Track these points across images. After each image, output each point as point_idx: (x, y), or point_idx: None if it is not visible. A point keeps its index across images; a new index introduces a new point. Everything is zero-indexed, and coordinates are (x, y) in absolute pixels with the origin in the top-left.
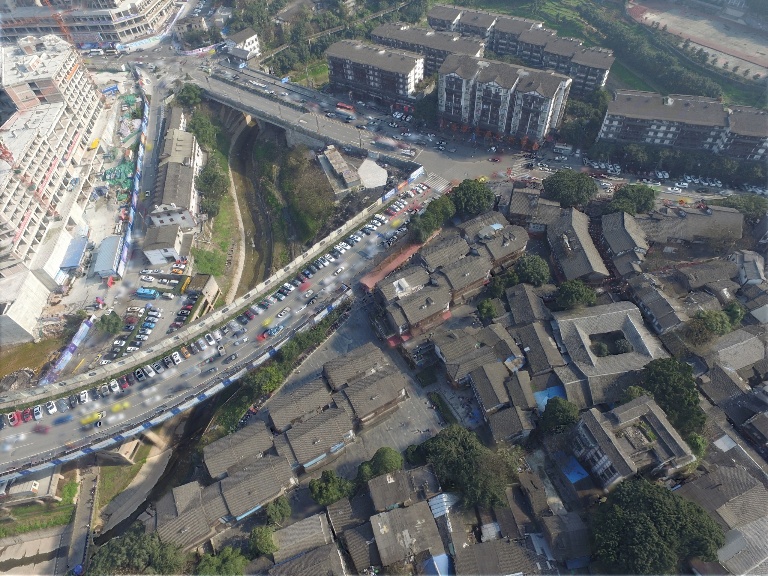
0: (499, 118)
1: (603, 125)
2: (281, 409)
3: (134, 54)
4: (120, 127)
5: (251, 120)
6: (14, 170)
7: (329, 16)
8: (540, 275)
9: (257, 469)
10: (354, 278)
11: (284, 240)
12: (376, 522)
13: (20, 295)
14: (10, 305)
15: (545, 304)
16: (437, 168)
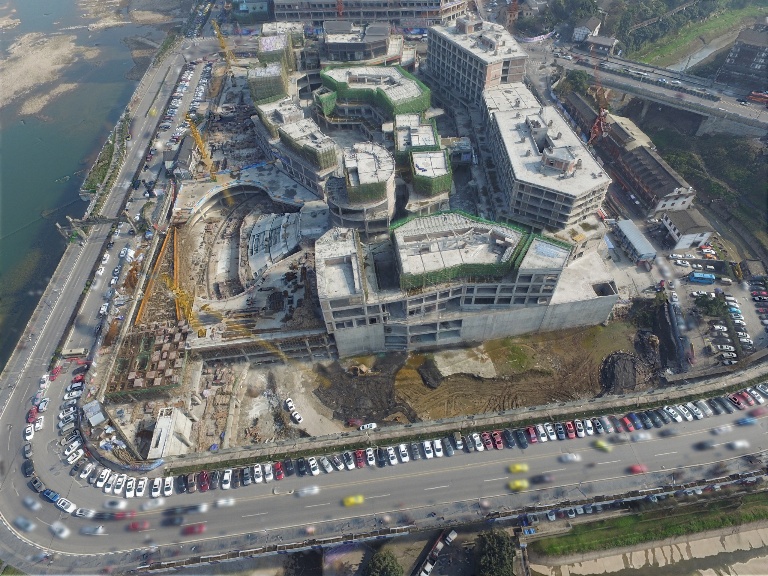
0: None
1: None
2: None
3: None
4: None
5: None
6: (589, 146)
7: (642, 7)
8: None
9: None
10: None
11: (764, 229)
12: None
13: None
14: (612, 285)
15: None
16: None
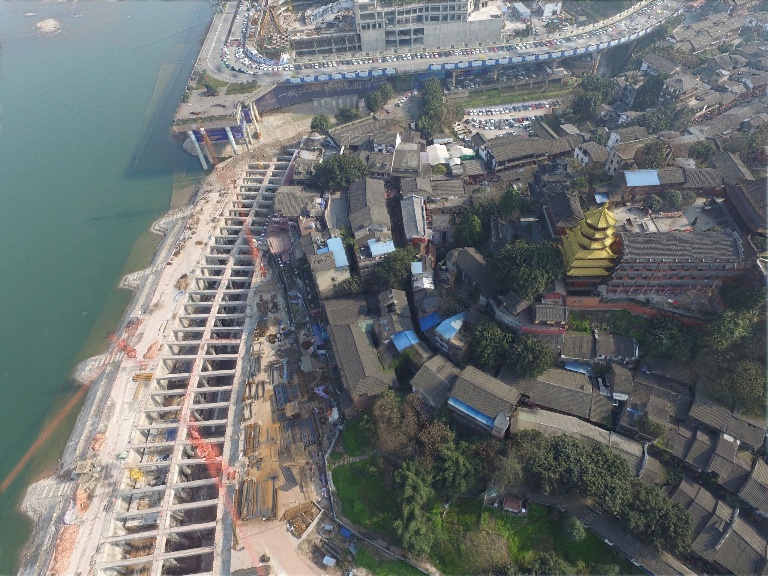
0: None
1: None
2: (695, 24)
3: None
4: None
5: None
6: None
7: None
8: None
9: None
10: None
11: (602, 16)
12: (761, 48)
13: None
14: None
15: None
16: None
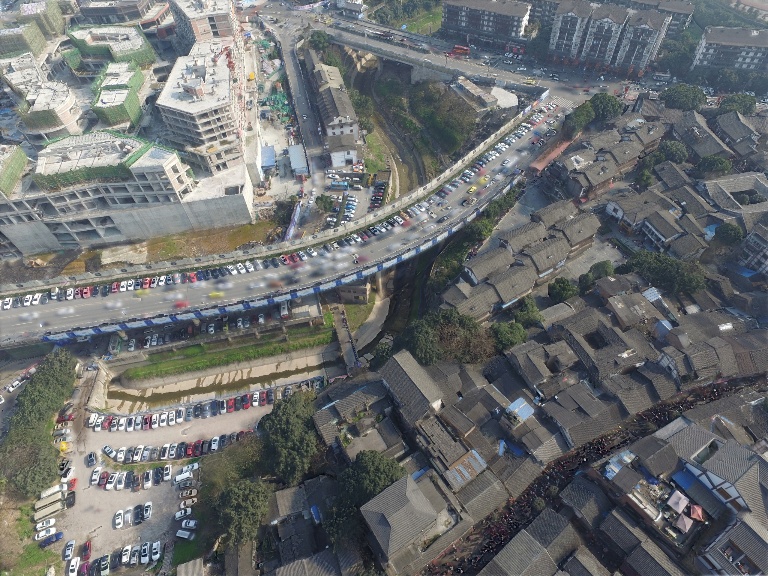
0: (607, 52)
1: (700, 53)
2: (515, 238)
3: (249, 9)
4: (263, 66)
5: (360, 67)
6: (233, 79)
7: None
8: (682, 153)
9: (514, 272)
10: (520, 167)
11: (430, 153)
12: (613, 301)
13: (246, 181)
14: (241, 188)
15: (688, 175)
16: (558, 92)
